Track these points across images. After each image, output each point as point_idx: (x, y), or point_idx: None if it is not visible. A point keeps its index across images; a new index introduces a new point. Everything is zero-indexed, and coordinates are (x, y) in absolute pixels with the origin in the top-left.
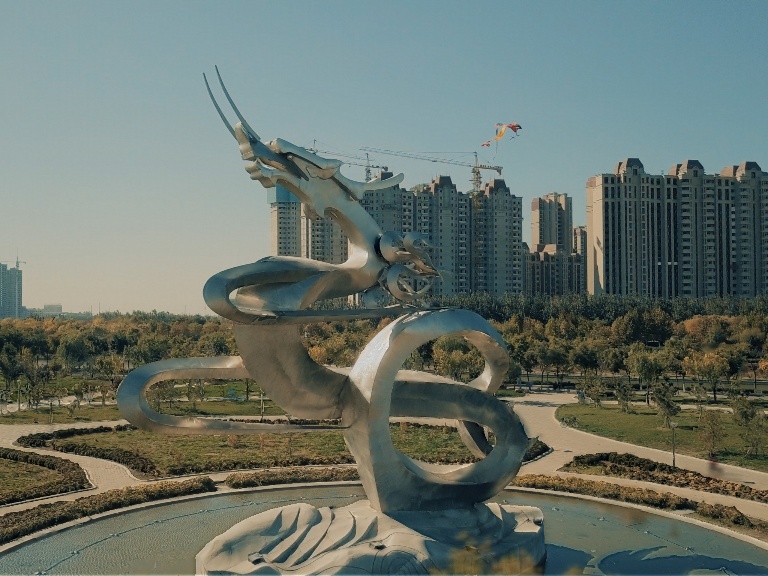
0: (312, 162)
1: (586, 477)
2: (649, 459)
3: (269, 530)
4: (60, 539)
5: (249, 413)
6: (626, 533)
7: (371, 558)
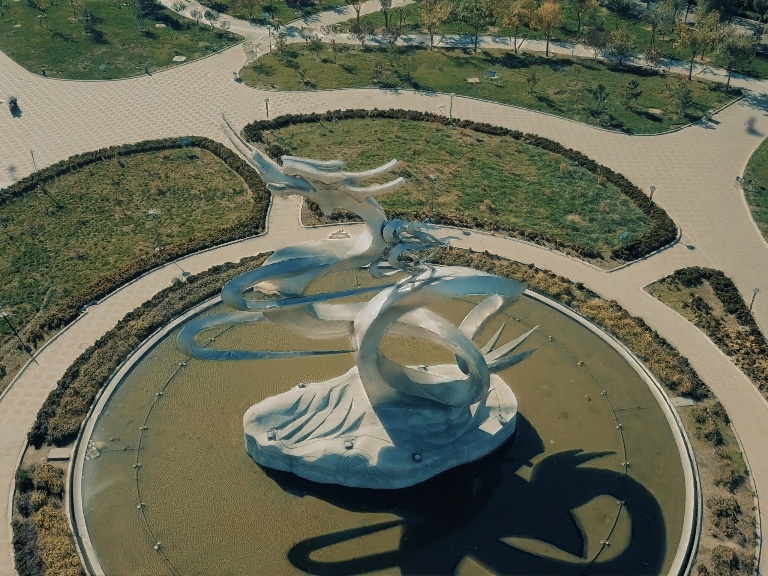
0: (317, 180)
1: (660, 308)
2: (741, 297)
3: (288, 411)
4: None
5: (455, 92)
6: (604, 420)
7: (338, 457)
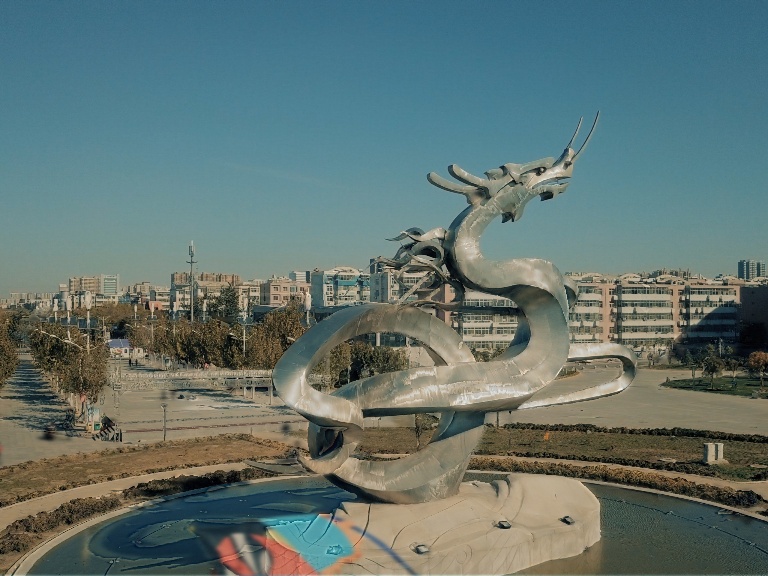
0: None
1: None
2: None
3: None
4: None
5: None
6: None
7: None
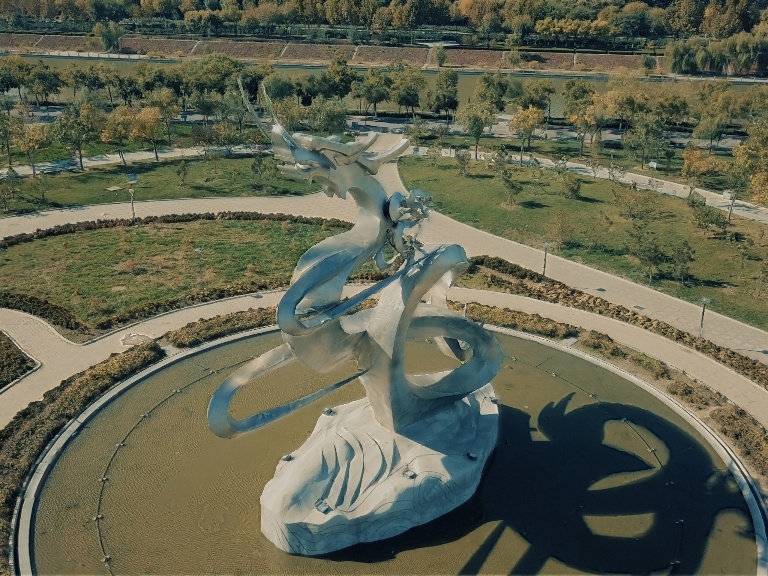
0: (340, 152)
1: (475, 293)
2: (518, 265)
3: (321, 475)
4: (72, 459)
5: (105, 201)
6: (539, 376)
7: (411, 490)
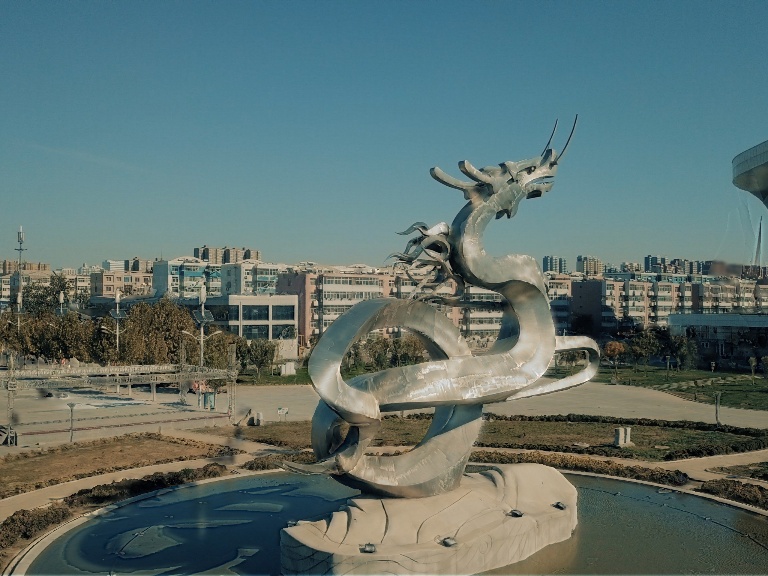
0: None
1: None
2: None
3: None
4: None
5: None
6: None
7: None
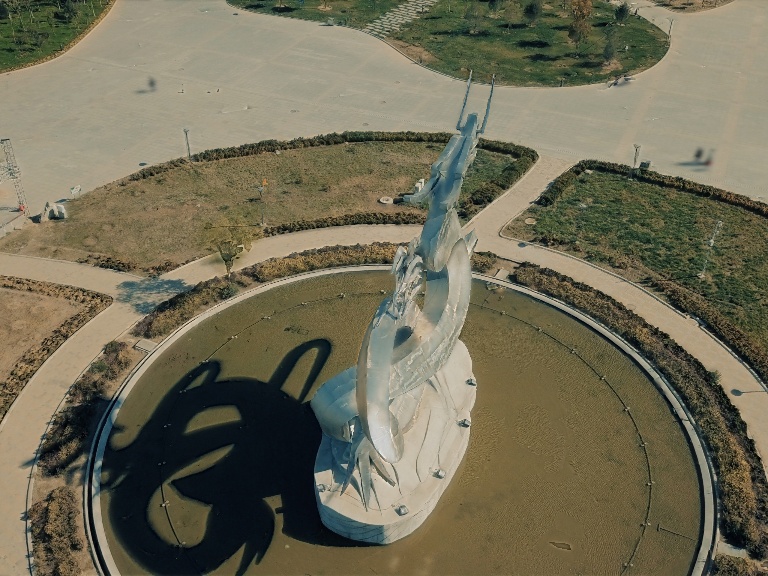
0: None
1: None
2: None
3: None
4: (648, 390)
5: None
6: None
7: None
